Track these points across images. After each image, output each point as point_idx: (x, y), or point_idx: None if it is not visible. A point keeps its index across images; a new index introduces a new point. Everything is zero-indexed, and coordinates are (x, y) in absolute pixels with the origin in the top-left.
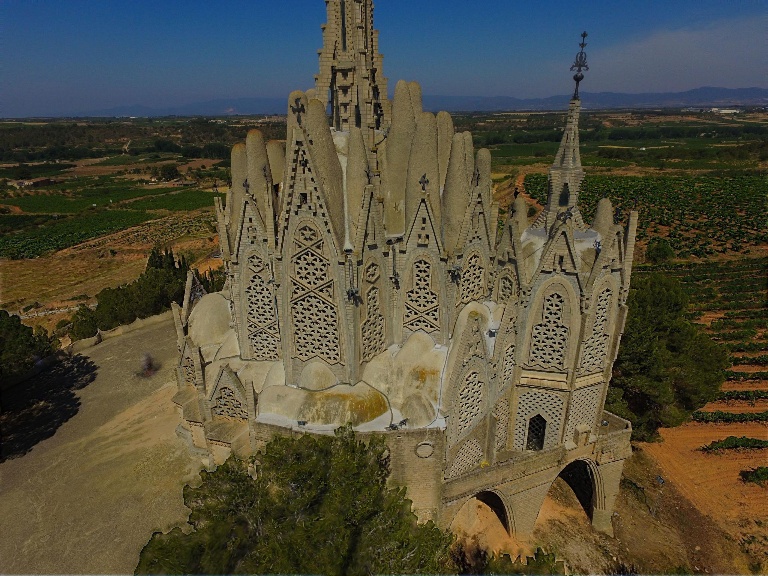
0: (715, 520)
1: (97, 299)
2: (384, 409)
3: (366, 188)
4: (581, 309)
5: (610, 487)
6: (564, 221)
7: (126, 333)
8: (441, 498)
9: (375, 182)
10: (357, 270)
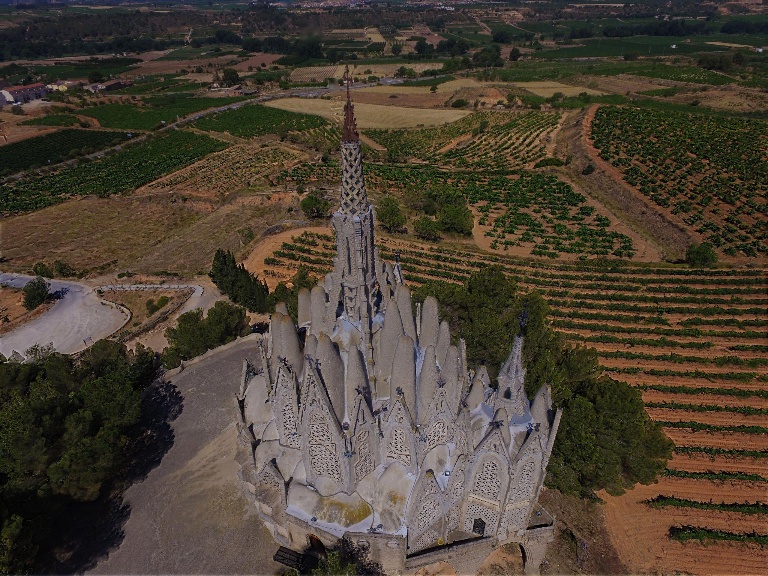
0: (630, 570)
1: (178, 322)
2: (369, 513)
3: (356, 398)
4: (509, 474)
5: (537, 555)
6: (497, 426)
7: (201, 361)
8: (404, 567)
9: (370, 367)
10: (351, 440)
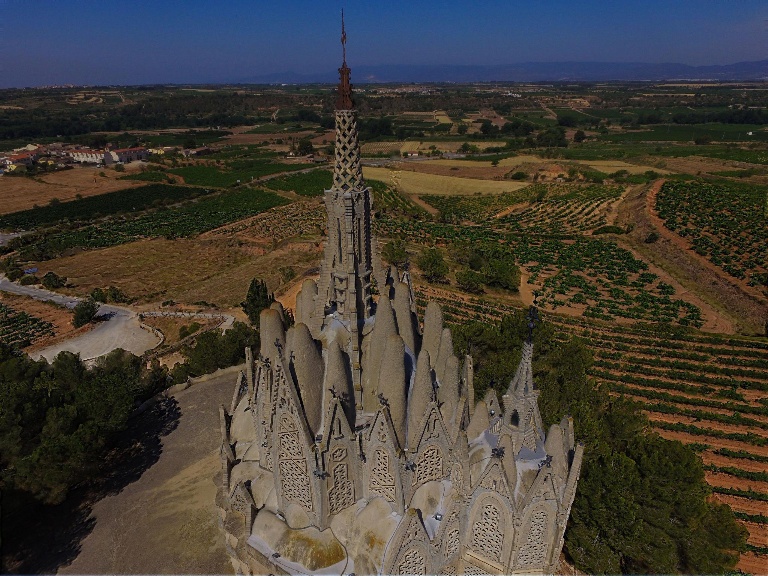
0: None
1: (196, 340)
2: (341, 558)
3: (331, 401)
4: (513, 524)
5: None
6: (498, 455)
7: (209, 380)
8: None
9: (355, 373)
10: (323, 456)
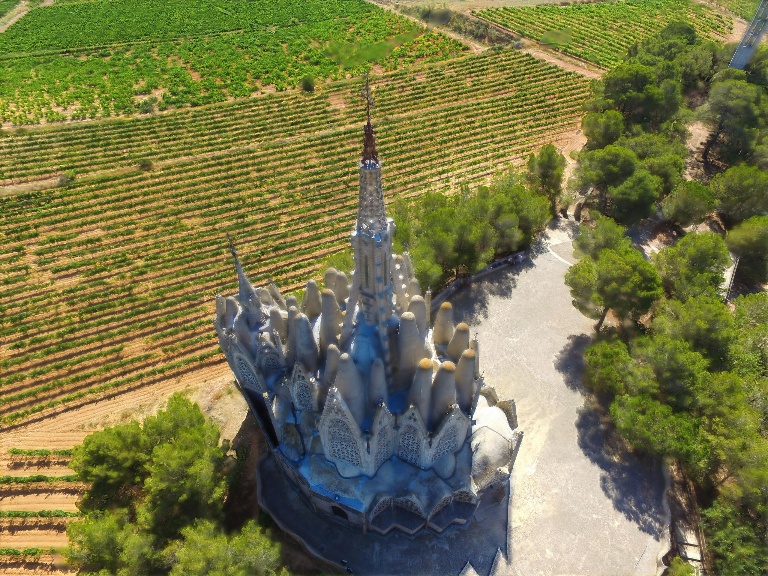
0: None
1: None
2: None
3: None
4: None
5: None
6: None
7: None
8: None
9: None
10: None
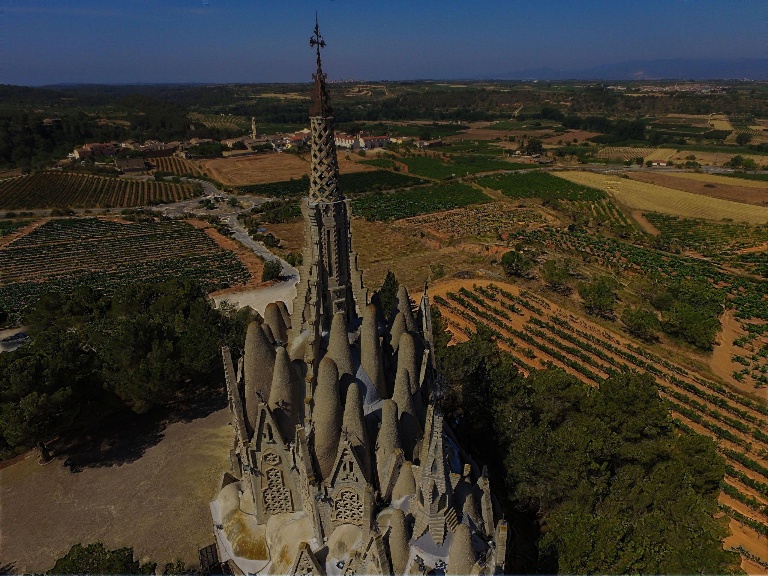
0: None
1: None
2: (263, 557)
3: (258, 405)
4: None
5: None
6: None
7: None
8: None
9: (307, 386)
10: (255, 454)
